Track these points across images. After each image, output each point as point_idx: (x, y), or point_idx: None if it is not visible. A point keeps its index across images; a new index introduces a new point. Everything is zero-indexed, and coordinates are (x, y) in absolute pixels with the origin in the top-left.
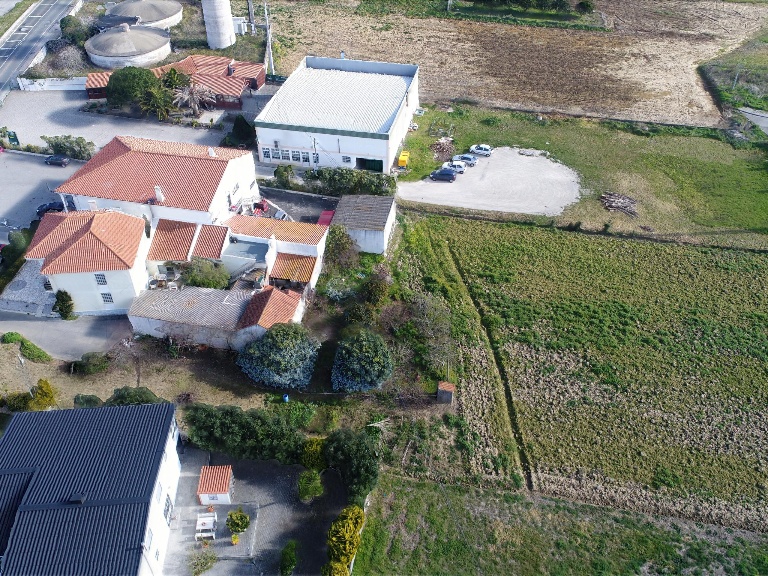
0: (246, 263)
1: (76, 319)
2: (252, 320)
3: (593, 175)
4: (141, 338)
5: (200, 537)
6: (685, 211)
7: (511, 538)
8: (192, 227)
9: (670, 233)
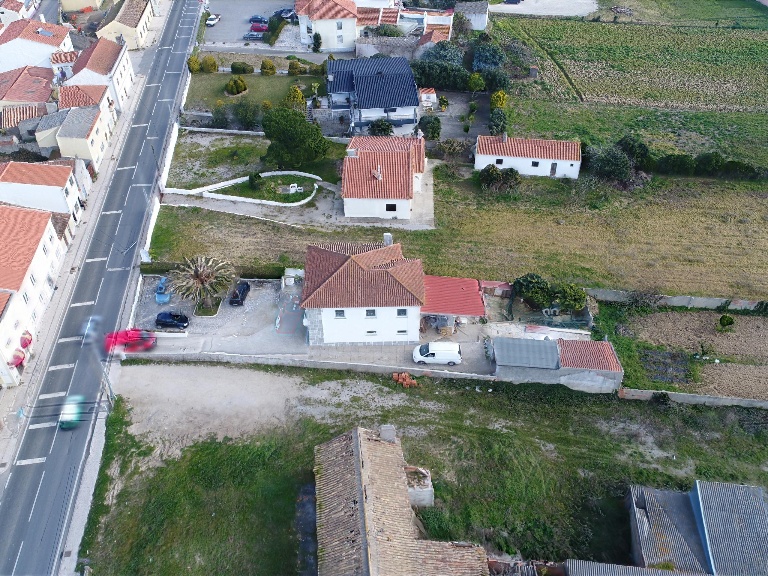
0: (413, 24)
1: (321, 53)
2: (426, 41)
3: (606, 0)
4: (362, 58)
5: (426, 109)
6: (663, 14)
7: (575, 111)
8: (378, 10)
9: (654, 22)
